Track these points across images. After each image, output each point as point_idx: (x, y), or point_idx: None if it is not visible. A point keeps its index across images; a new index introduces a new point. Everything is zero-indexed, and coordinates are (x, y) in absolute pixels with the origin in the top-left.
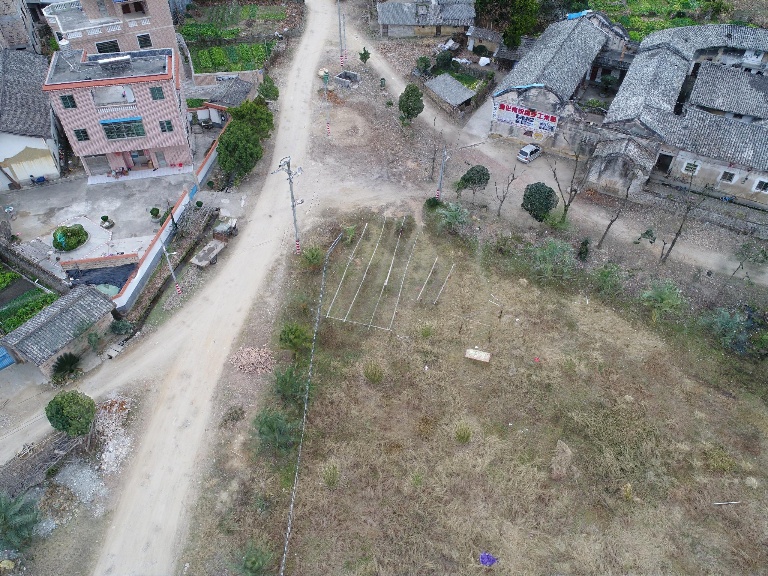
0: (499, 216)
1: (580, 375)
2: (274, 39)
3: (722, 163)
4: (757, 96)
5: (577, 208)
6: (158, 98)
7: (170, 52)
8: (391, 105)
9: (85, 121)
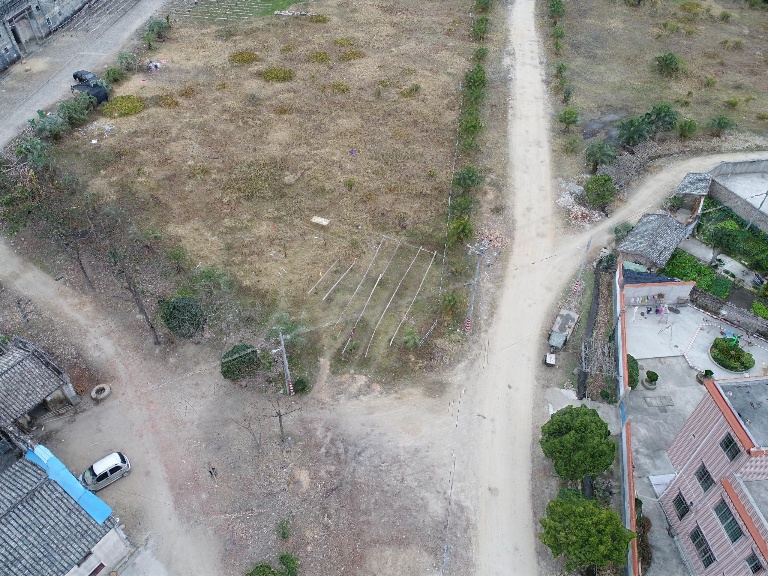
0: None
1: None
2: None
3: None
4: None
5: (119, 366)
6: None
7: None
8: None
9: None
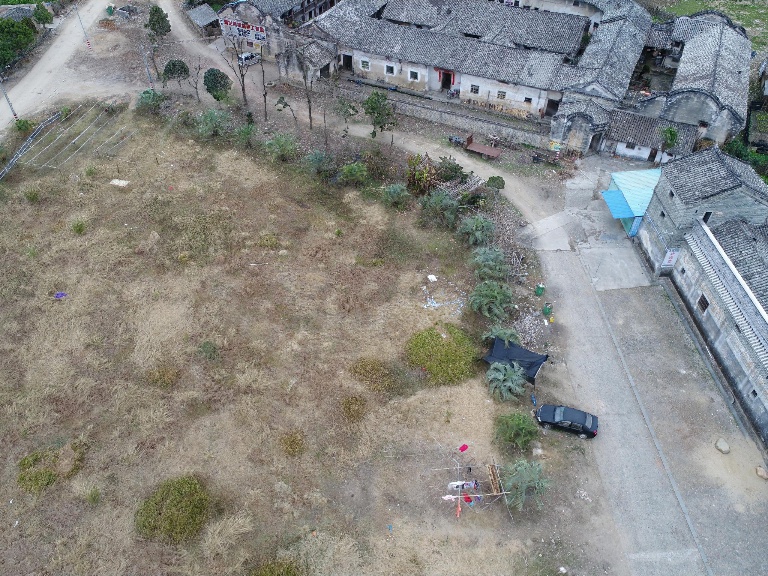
0: (199, 102)
1: (198, 196)
2: None
3: (381, 58)
4: (432, 10)
5: None
6: None
7: None
8: (148, 27)
9: None
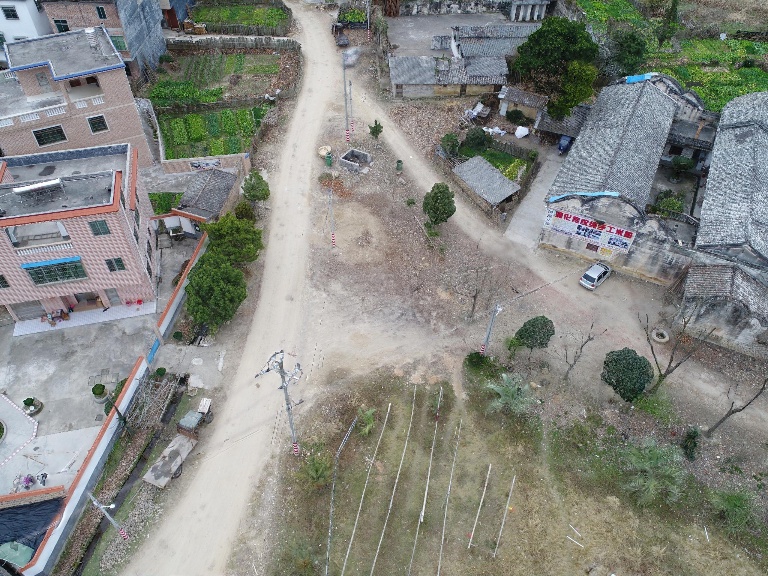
0: (566, 380)
1: None
2: (264, 103)
3: None
4: None
5: None
6: (101, 233)
7: (126, 148)
8: (412, 204)
9: (1, 266)
